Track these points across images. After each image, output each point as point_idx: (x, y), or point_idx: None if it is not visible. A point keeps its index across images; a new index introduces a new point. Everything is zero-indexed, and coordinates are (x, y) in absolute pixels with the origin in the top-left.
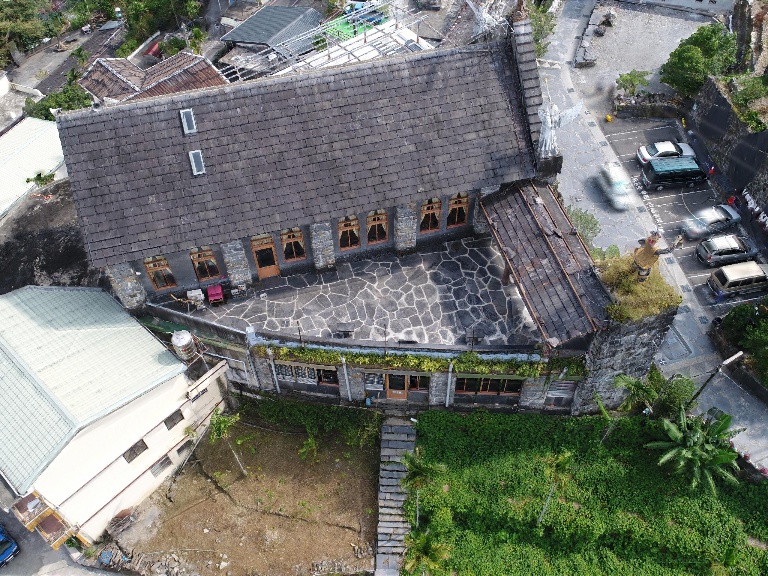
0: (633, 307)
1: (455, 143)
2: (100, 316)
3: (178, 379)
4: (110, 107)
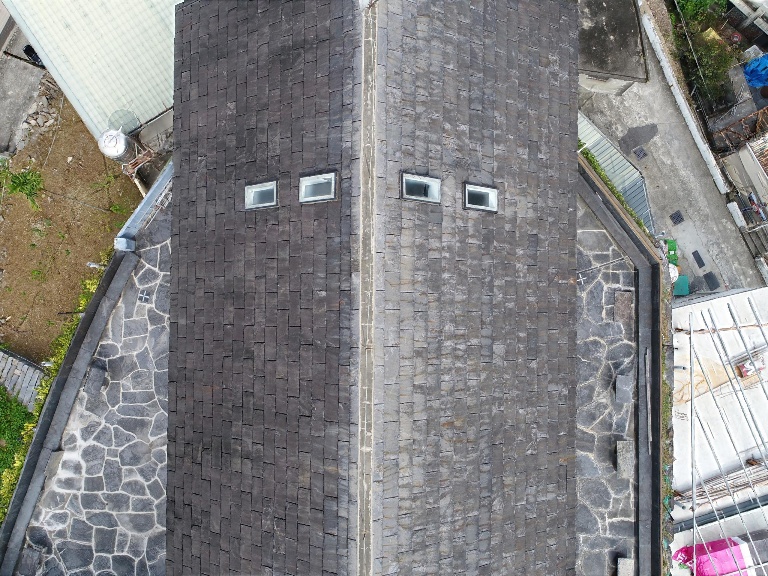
0: None
1: None
2: None
3: None
4: (365, 27)
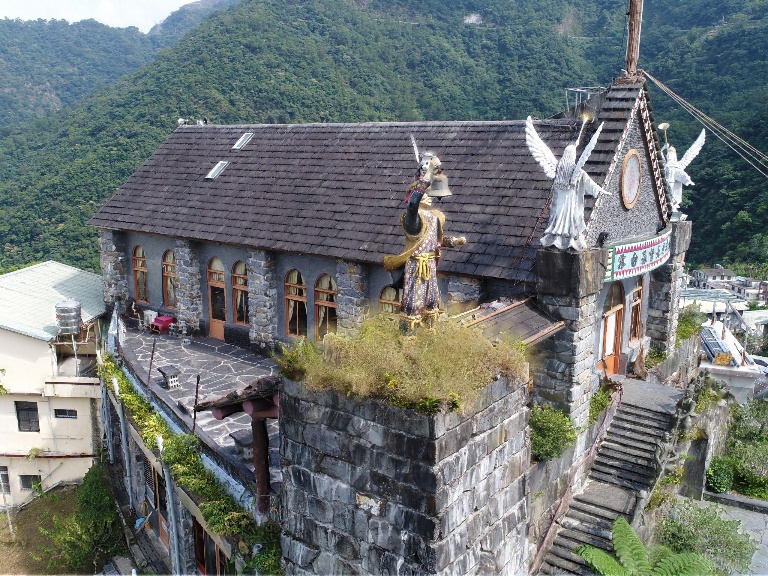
0: (338, 367)
1: (447, 211)
2: (90, 301)
3: (46, 357)
4: None
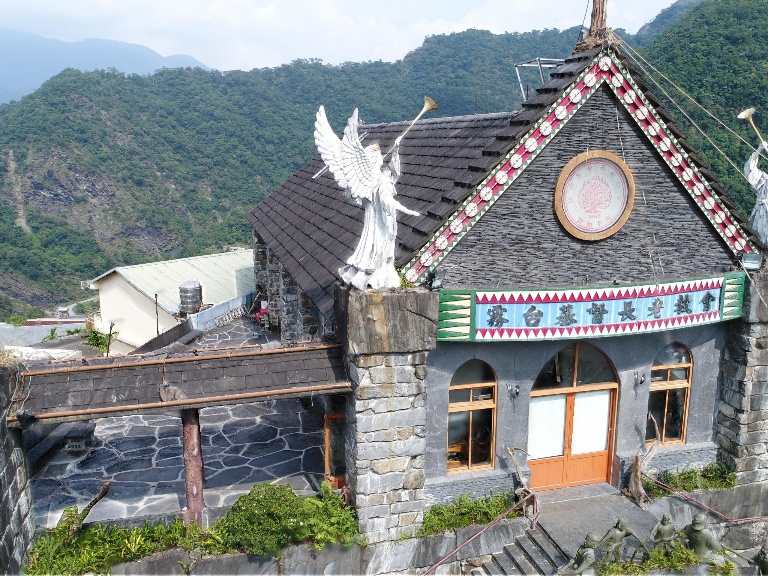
0: None
1: None
2: None
3: None
4: None
